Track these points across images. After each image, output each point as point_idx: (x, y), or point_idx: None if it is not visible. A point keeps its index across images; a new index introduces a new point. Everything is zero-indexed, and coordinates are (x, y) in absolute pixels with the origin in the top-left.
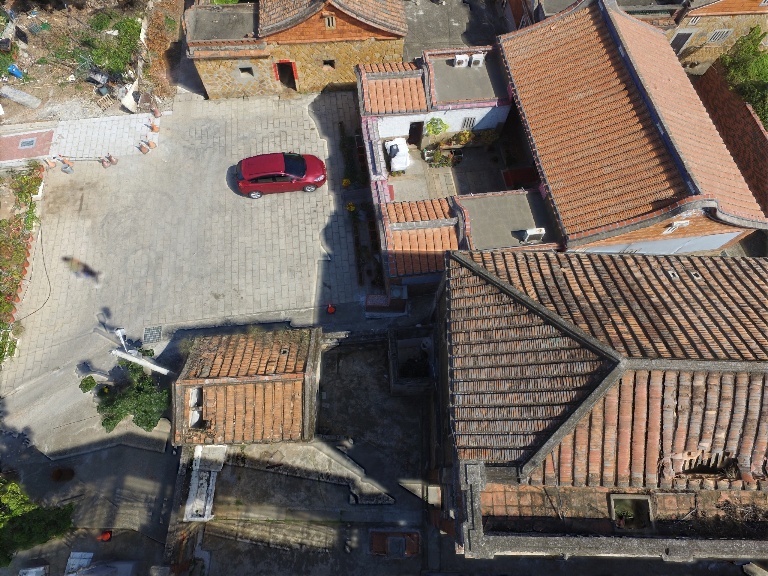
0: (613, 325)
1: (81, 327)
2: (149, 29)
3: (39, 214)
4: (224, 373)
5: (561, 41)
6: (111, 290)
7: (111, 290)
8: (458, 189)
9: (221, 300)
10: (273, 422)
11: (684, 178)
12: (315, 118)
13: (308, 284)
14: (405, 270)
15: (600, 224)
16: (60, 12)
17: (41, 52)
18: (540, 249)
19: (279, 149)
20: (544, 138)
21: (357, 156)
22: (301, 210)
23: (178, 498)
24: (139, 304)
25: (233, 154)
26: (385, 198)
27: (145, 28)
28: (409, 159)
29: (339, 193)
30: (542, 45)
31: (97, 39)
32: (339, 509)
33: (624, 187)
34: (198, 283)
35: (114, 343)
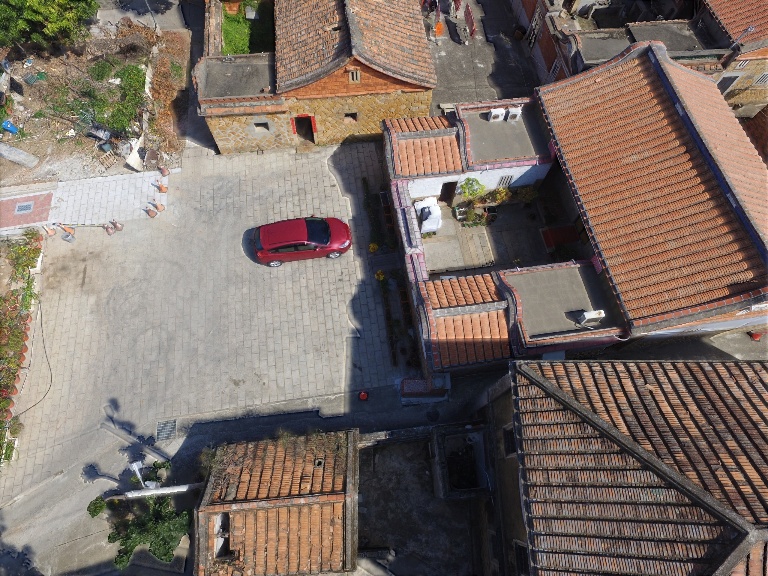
0: (725, 471)
1: (86, 422)
2: (154, 77)
3: (38, 290)
4: (253, 494)
5: (608, 95)
6: (119, 377)
7: (119, 377)
8: (494, 251)
9: (241, 387)
10: (310, 550)
11: (765, 260)
12: (336, 173)
13: (336, 366)
14: (450, 361)
15: (669, 309)
16: (58, 59)
17: (38, 104)
18: (600, 335)
19: (298, 209)
20: (596, 205)
21: (383, 216)
22: (325, 279)
23: None
24: (150, 393)
25: (248, 216)
26: (422, 273)
27: (149, 76)
28: (441, 220)
29: (365, 258)
30: (586, 99)
31: (99, 95)
32: None
33: (694, 266)
34: (215, 367)
35: (124, 441)
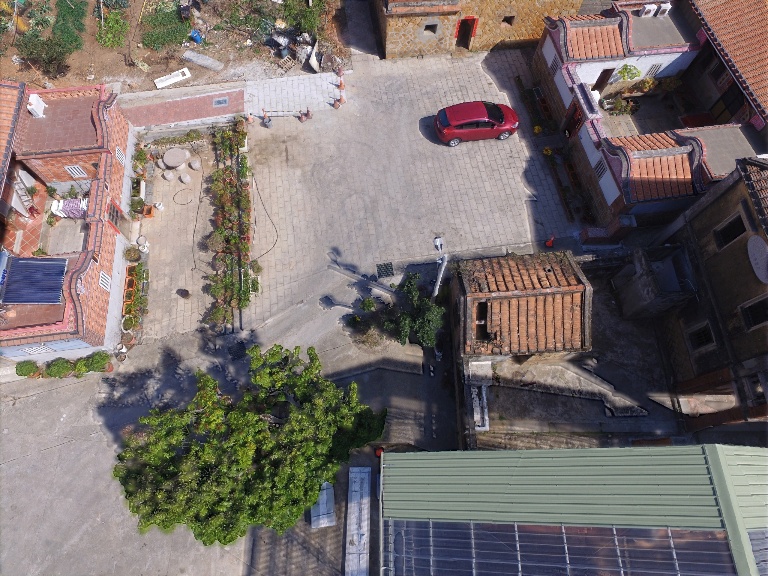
0: None
1: (315, 265)
2: None
3: (249, 165)
4: (503, 288)
5: None
6: (335, 231)
7: (335, 231)
8: None
9: (442, 238)
10: (554, 332)
11: None
12: (490, 74)
13: (521, 222)
14: (644, 196)
15: None
16: None
17: (214, 20)
18: None
19: None
20: (754, 74)
21: (539, 107)
22: (498, 156)
23: (472, 405)
24: (365, 243)
25: (420, 107)
26: (603, 135)
27: None
28: None
29: (530, 140)
30: None
31: (289, 0)
32: (598, 421)
33: None
34: (416, 223)
35: (350, 278)
